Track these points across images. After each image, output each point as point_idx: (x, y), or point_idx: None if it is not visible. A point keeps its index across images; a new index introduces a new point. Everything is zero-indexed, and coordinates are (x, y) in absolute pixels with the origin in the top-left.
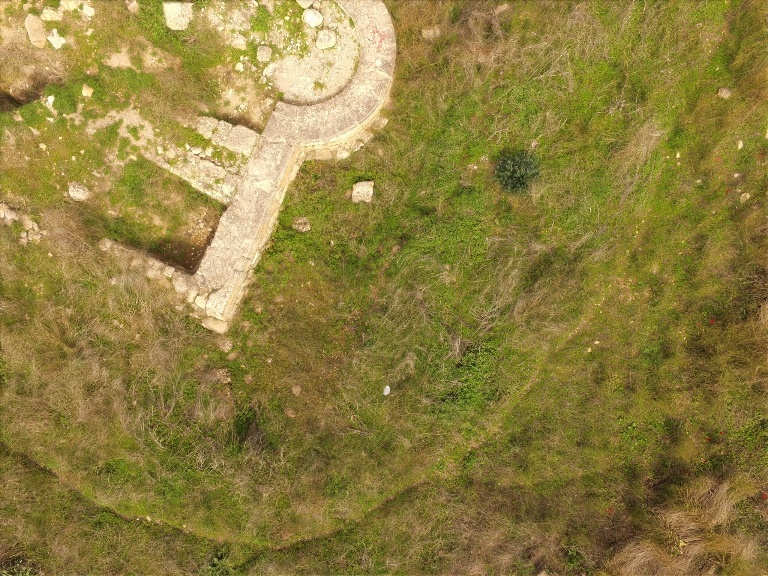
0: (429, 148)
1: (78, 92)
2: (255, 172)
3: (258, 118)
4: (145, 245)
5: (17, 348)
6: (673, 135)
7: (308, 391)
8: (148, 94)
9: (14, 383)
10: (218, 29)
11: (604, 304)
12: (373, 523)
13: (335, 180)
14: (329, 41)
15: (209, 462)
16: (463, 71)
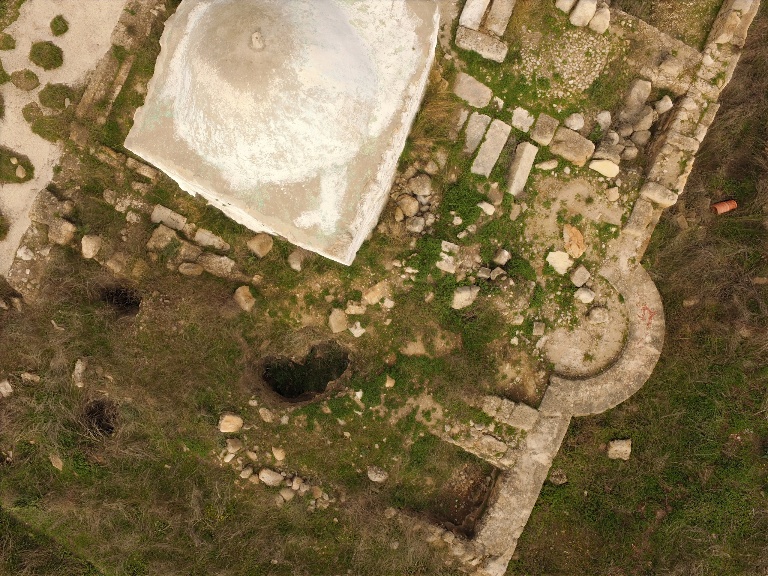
0: (687, 412)
1: (382, 384)
2: (533, 445)
3: (533, 391)
4: (420, 506)
5: None
6: None
7: None
8: (441, 380)
9: None
10: None
11: None
12: None
13: (592, 436)
14: (603, 320)
15: None
16: (727, 345)
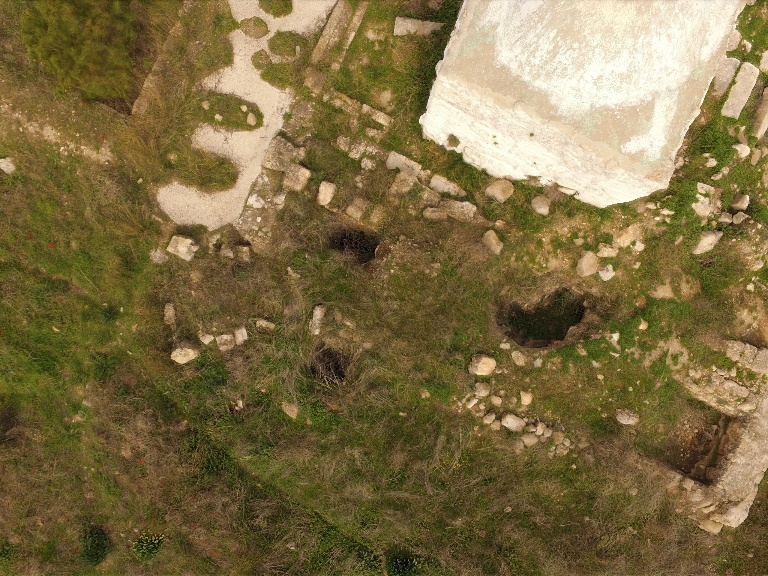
0: None
1: (636, 326)
2: None
3: None
4: (653, 453)
5: (557, 561)
6: None
7: None
8: (689, 323)
9: None
10: (747, 258)
11: None
12: None
13: None
14: None
15: None
16: None
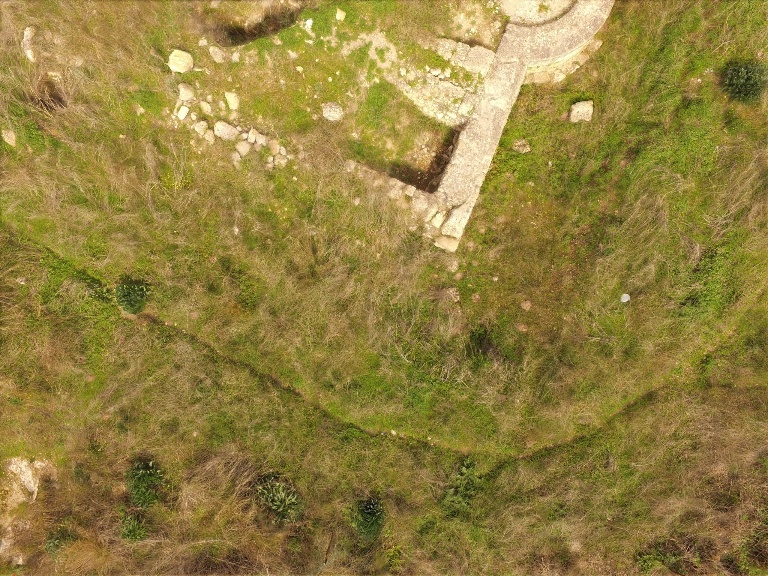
0: (647, 66)
1: (332, 16)
2: (491, 91)
3: (489, 40)
4: (381, 168)
5: (273, 267)
6: None
7: (540, 305)
8: (393, 17)
9: (268, 302)
10: None
11: None
12: (616, 427)
13: (553, 102)
14: None
15: (454, 374)
16: None
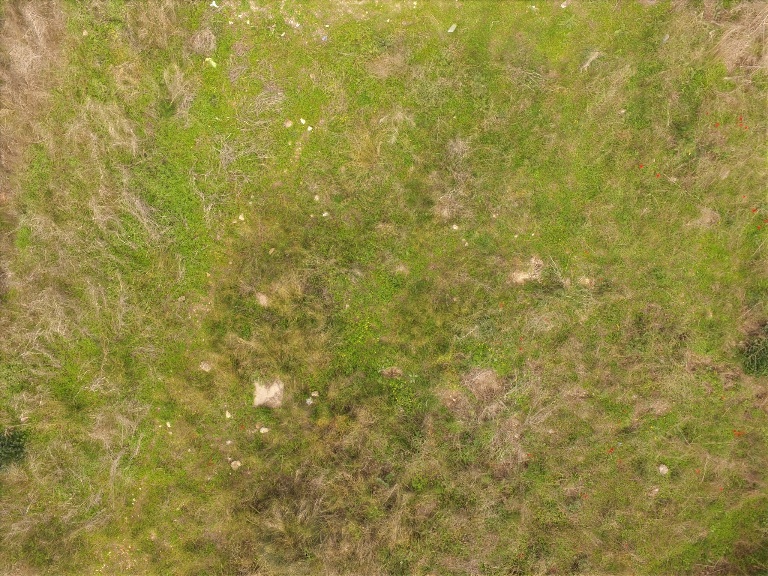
0: None
1: None
2: None
3: None
4: None
5: None
6: (161, 406)
7: None
8: None
9: None
10: None
11: (105, 571)
12: None
13: None
14: None
15: None
16: None
